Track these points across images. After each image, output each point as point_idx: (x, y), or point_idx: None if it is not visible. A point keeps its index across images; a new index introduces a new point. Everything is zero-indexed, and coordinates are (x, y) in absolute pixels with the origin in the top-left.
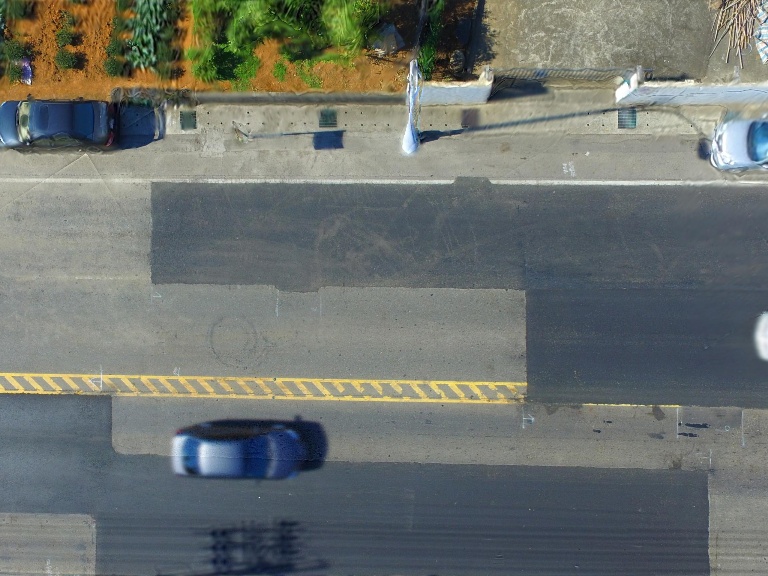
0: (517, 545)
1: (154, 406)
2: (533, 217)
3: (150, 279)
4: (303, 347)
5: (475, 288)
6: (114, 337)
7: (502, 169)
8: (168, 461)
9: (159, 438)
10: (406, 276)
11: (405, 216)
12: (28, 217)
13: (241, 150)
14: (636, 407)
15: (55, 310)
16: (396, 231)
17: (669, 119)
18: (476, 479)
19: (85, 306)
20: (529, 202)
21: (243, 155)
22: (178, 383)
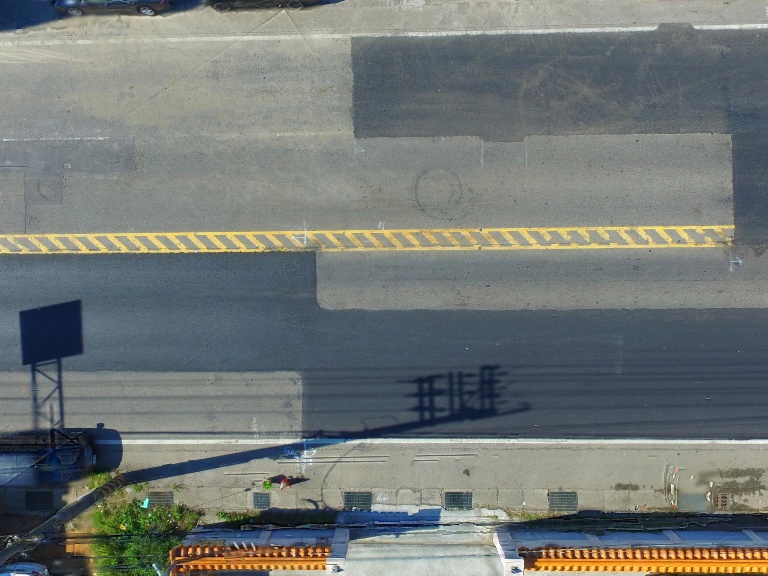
0: (726, 387)
1: (359, 261)
2: (737, 61)
3: (353, 134)
4: (509, 197)
5: (681, 133)
6: (317, 193)
7: (705, 14)
8: (374, 315)
9: (365, 292)
10: (611, 123)
11: (608, 64)
12: (226, 75)
13: (441, 3)
14: None
15: (257, 168)
16: (600, 79)
17: None
18: (684, 323)
19: (287, 163)
20: (733, 46)
21: (443, 8)
22: (383, 237)
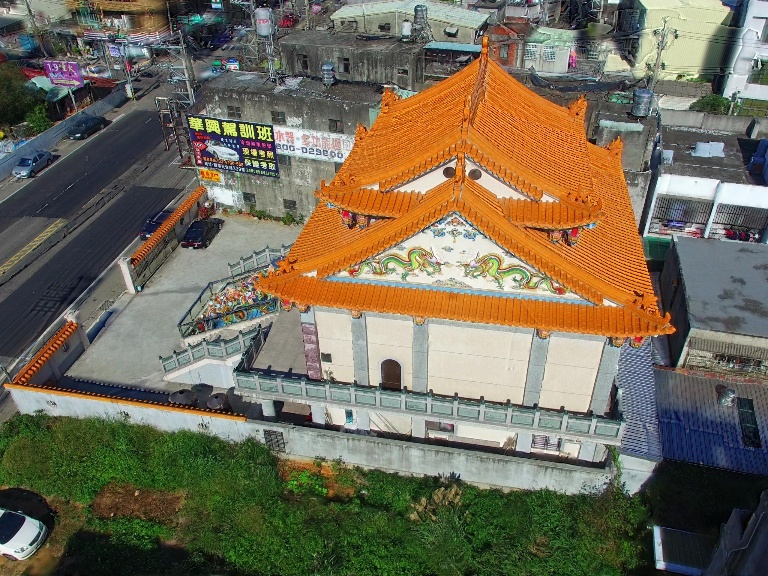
0: None
1: None
2: None
3: None
4: None
5: (9, 227)
6: None
7: None
8: None
9: None
10: None
11: None
12: None
13: None
14: (95, 197)
15: None
16: None
17: (0, 186)
18: None
19: None
20: None
21: None
22: None
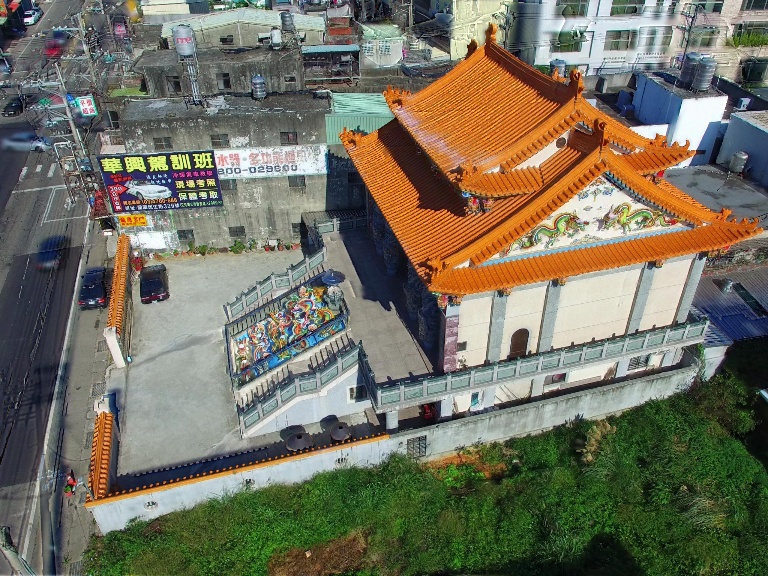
0: None
1: None
2: None
3: None
4: None
5: None
6: None
7: None
8: None
9: None
10: None
11: None
12: None
13: None
14: None
15: None
16: None
17: None
18: None
19: None
20: None
21: None
22: None
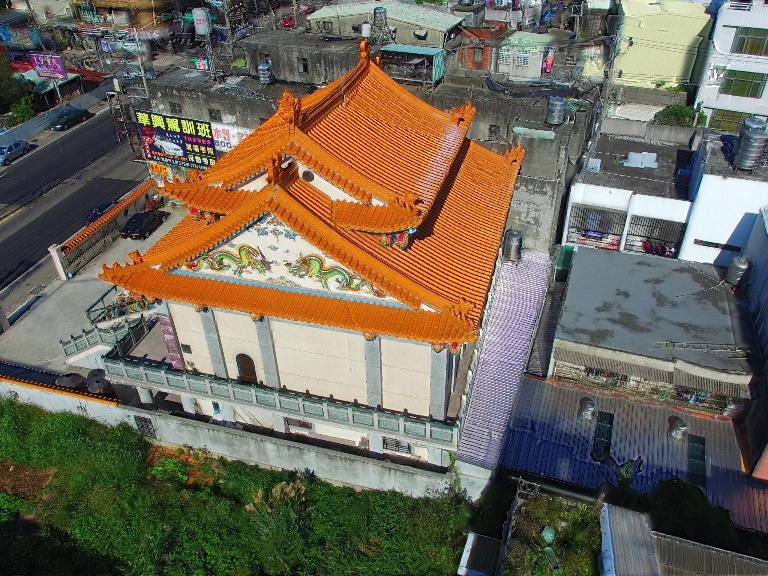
0: None
1: None
2: None
3: None
4: None
5: None
6: None
7: None
8: None
9: None
10: None
11: None
12: None
13: None
14: None
15: None
16: None
17: None
18: (40, 220)
19: None
20: None
21: None
22: None
